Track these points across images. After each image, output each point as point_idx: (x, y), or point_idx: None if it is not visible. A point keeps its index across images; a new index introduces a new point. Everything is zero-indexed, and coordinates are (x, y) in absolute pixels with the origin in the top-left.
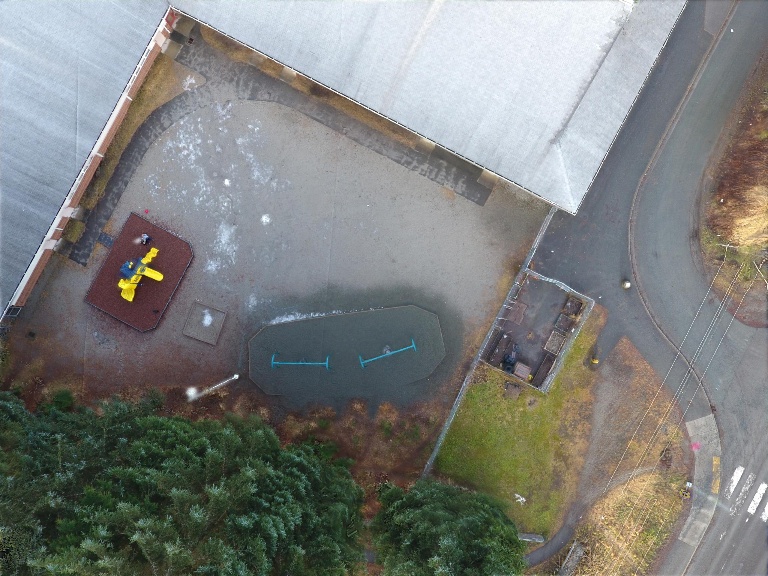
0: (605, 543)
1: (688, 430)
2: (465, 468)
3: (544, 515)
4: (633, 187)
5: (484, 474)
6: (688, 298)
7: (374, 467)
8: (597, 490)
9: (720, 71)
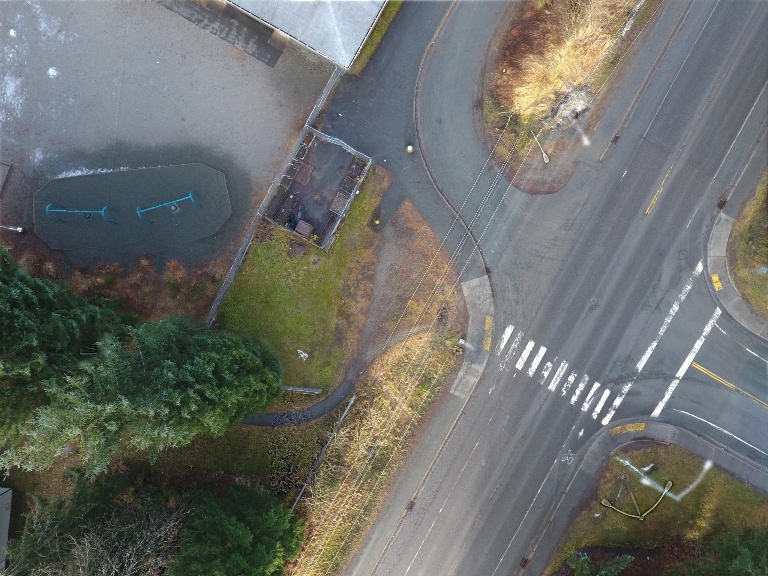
0: (383, 397)
1: (463, 290)
2: (250, 325)
3: (325, 370)
4: (420, 54)
5: (268, 330)
6: (469, 164)
7: None
8: (377, 347)
9: None
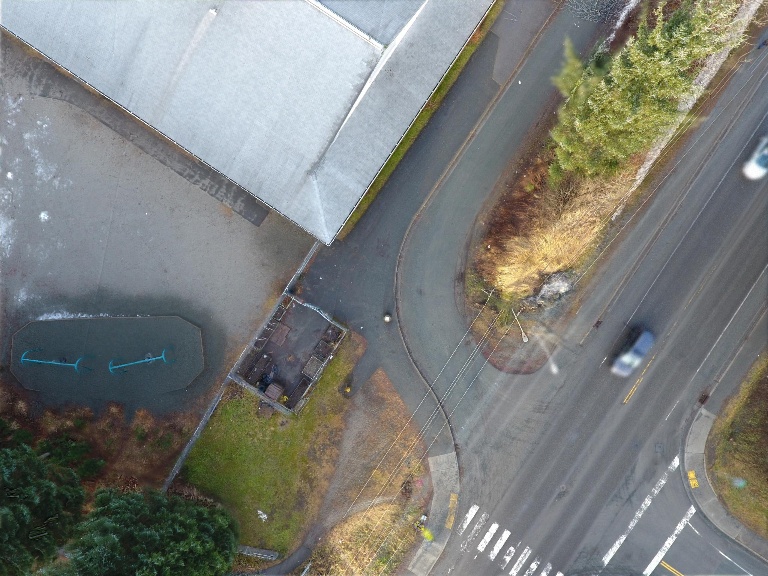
0: (340, 566)
1: (430, 465)
2: (213, 480)
3: (284, 533)
4: (405, 224)
5: (230, 488)
6: (446, 338)
7: (125, 470)
8: (338, 514)
9: (503, 120)
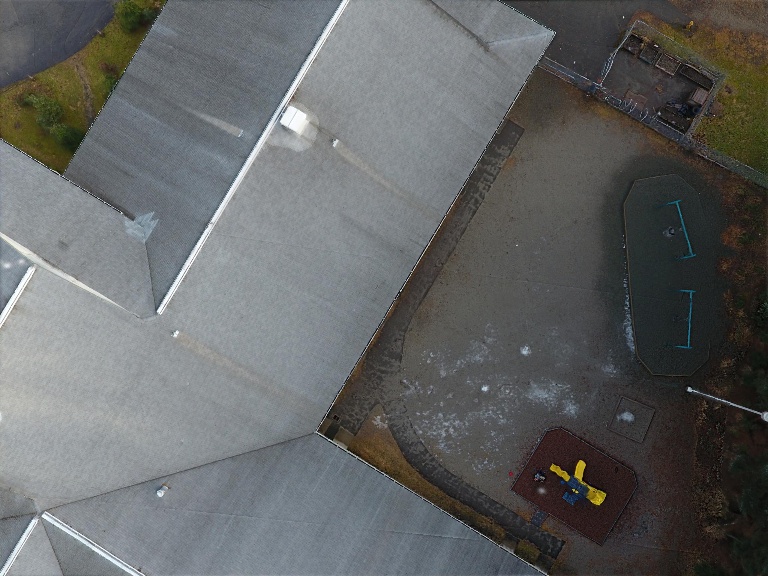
0: None
1: None
2: None
3: None
4: None
5: None
6: None
7: None
8: None
9: None
